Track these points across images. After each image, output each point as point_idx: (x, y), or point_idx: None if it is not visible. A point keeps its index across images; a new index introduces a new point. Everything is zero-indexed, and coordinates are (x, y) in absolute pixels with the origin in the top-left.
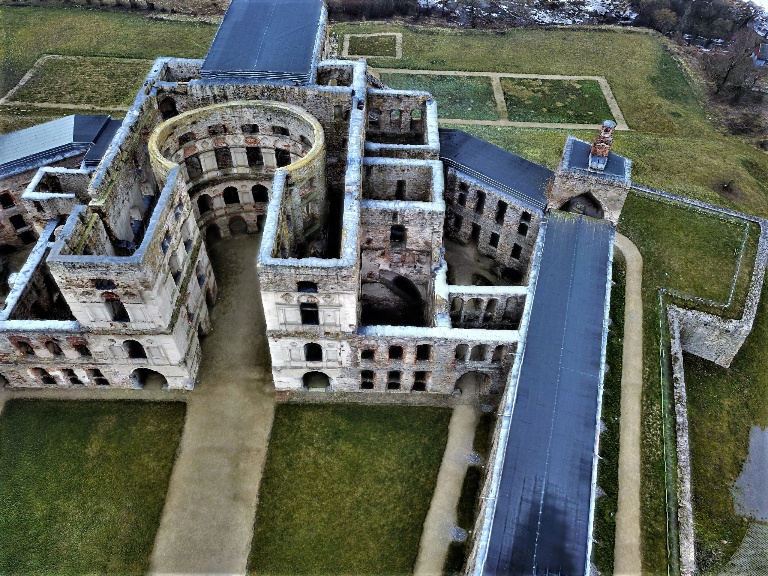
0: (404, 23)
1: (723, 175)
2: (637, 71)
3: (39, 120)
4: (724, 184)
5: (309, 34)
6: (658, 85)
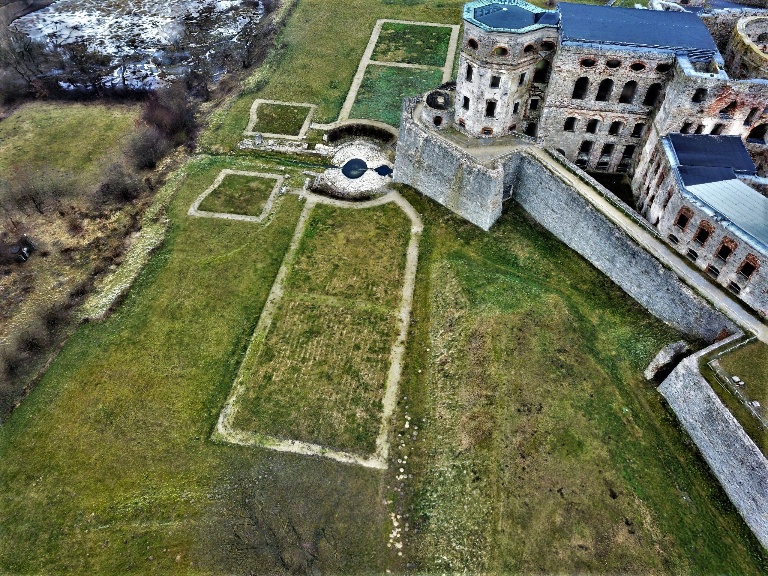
0: (228, 96)
1: (534, 2)
2: (373, 5)
3: (495, 357)
4: (545, 3)
5: (628, 9)
6: (397, 3)
